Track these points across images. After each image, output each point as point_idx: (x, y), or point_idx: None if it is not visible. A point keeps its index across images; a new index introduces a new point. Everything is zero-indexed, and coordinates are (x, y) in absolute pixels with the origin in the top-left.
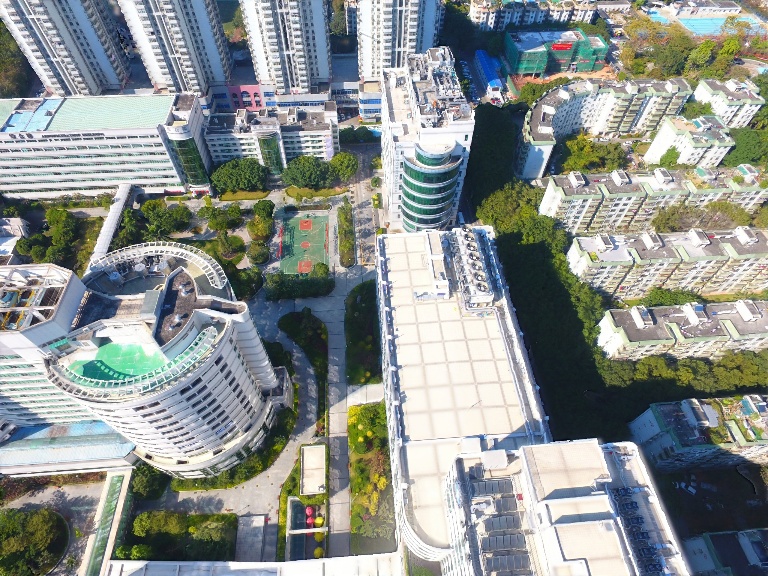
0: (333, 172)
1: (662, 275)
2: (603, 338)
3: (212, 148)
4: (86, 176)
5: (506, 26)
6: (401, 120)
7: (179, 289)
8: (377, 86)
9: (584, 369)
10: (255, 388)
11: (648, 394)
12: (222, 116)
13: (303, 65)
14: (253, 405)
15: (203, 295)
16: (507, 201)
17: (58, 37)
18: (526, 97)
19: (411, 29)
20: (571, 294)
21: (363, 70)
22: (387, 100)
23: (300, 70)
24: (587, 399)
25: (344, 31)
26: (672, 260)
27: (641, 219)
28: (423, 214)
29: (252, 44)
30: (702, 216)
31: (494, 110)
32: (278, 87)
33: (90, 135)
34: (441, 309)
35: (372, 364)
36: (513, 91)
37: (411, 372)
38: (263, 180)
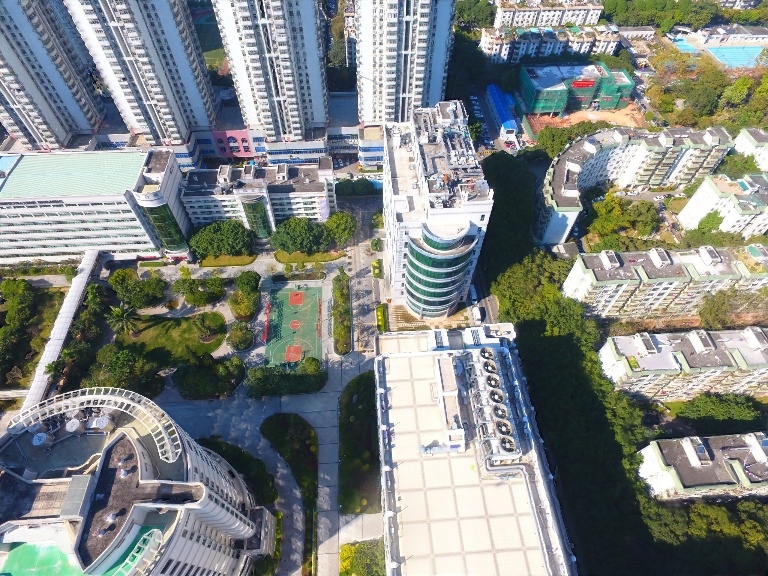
0: (328, 236)
1: (712, 381)
2: (647, 470)
3: (190, 210)
4: (46, 243)
5: (521, 58)
6: (406, 191)
7: (118, 467)
8: (379, 131)
9: (626, 514)
10: (224, 551)
11: (707, 557)
12: (203, 172)
13: (295, 112)
14: (222, 570)
15: (147, 480)
16: (527, 278)
17: (16, 83)
18: (544, 143)
19: (418, 74)
20: (606, 407)
21: (363, 114)
22: (390, 164)
23: (292, 117)
24: (628, 546)
25: (344, 61)
26: (727, 368)
27: (682, 302)
28: (430, 296)
29: (238, 88)
30: (752, 298)
31: (510, 162)
32: (268, 134)
33: (47, 202)
34: (455, 467)
35: (369, 488)
36: (529, 134)
37: (417, 568)
38: (248, 245)
